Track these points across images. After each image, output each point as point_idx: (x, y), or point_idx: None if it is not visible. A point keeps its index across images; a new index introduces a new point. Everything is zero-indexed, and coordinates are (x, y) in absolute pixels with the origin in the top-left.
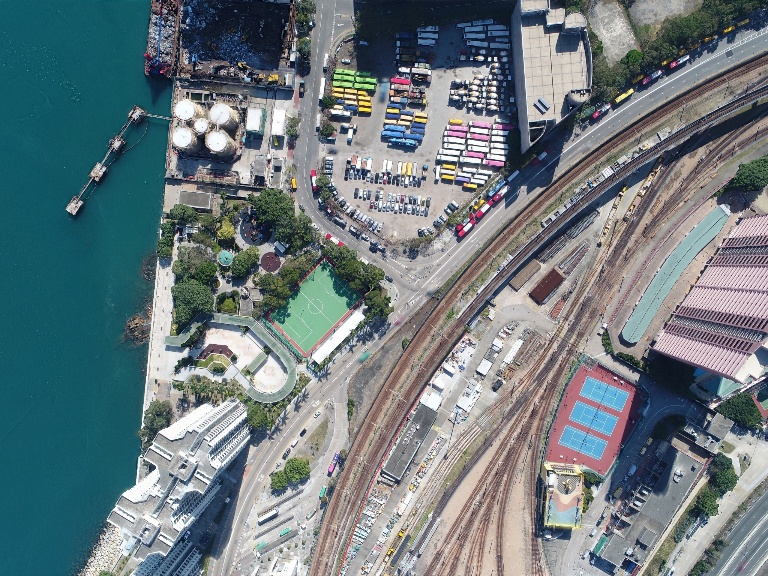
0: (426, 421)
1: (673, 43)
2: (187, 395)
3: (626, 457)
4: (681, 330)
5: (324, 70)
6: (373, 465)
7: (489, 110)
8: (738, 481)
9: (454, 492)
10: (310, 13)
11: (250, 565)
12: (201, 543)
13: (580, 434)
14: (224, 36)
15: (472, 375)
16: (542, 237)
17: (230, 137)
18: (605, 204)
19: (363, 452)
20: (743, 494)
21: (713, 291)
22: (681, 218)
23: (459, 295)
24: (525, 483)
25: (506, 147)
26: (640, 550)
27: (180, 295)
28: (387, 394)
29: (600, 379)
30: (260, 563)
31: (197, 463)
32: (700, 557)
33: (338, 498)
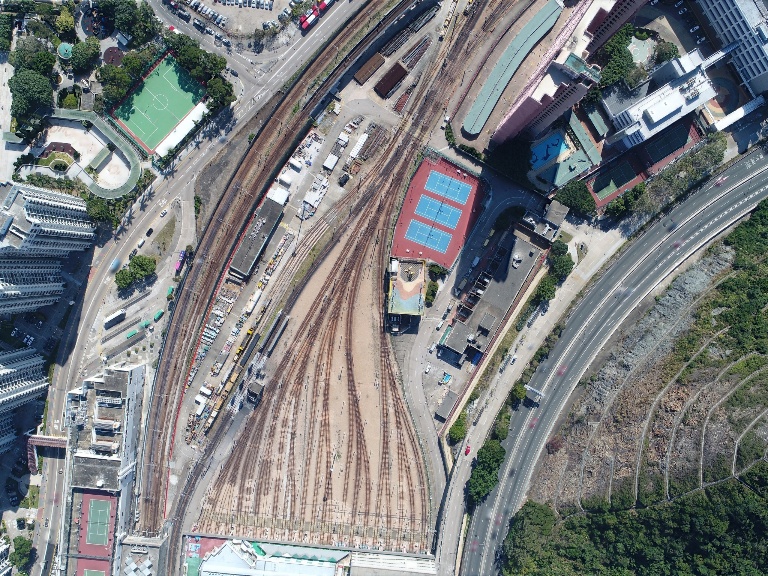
0: (272, 215)
1: None
2: None
3: (470, 250)
4: None
5: None
6: (220, 262)
7: None
8: (576, 270)
9: (303, 289)
10: None
11: (97, 371)
12: (45, 349)
13: (425, 228)
14: None
15: (319, 170)
16: (383, 26)
17: None
18: None
19: (211, 251)
20: (581, 283)
21: None
22: (519, 13)
23: (305, 89)
24: (373, 279)
25: None
26: (482, 337)
27: (16, 85)
28: (234, 191)
29: (444, 173)
30: None
31: (12, 217)
32: (541, 345)
33: (186, 298)
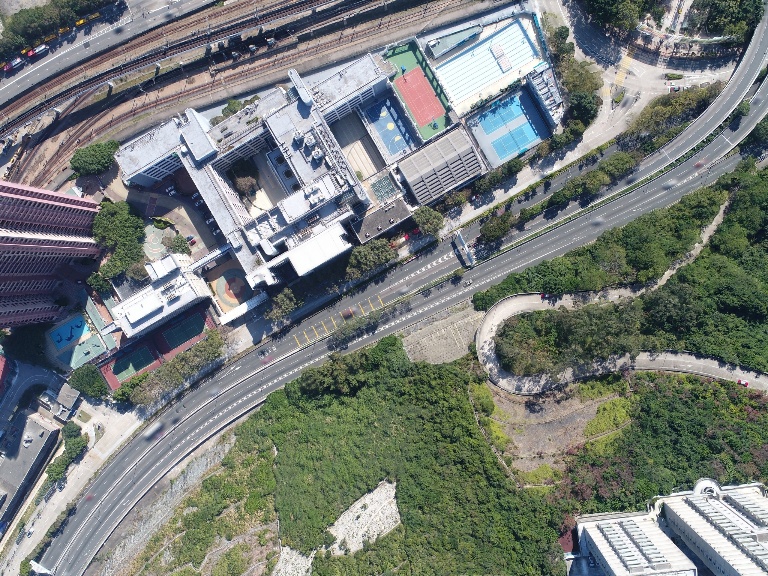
0: None
1: (17, 32)
2: None
3: None
4: None
5: None
6: None
7: None
8: (93, 449)
9: None
10: None
11: None
12: None
13: None
14: None
15: None
16: None
17: None
18: None
19: None
20: (98, 461)
21: None
22: None
23: None
24: None
25: None
26: None
27: None
28: None
29: None
30: None
31: None
32: None
33: None
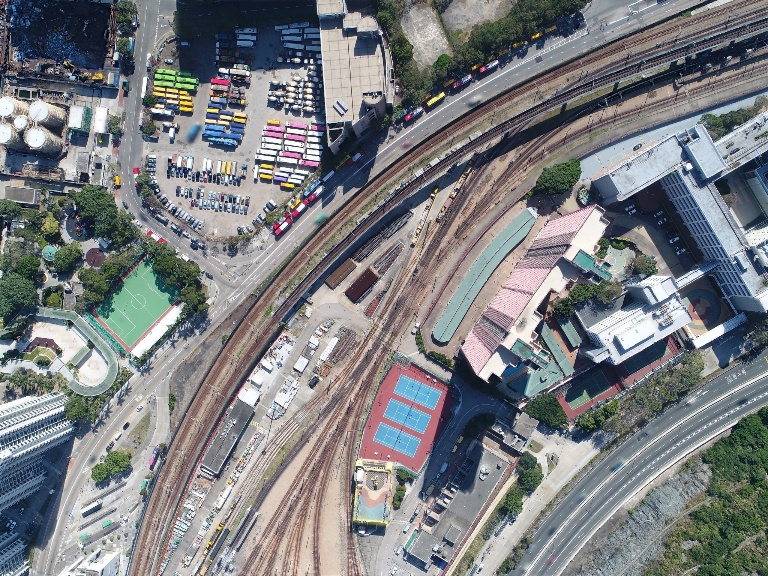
0: (243, 416)
1: (478, 48)
2: (14, 387)
3: (439, 455)
4: (478, 330)
5: (148, 70)
6: (192, 459)
7: (306, 111)
8: (546, 480)
9: (272, 487)
10: (131, 14)
11: (74, 556)
12: (26, 534)
13: (394, 431)
14: (50, 35)
15: (290, 372)
16: (353, 237)
17: (53, 134)
18: (418, 205)
19: (184, 446)
20: (551, 493)
21: (506, 292)
22: (492, 220)
23: (277, 293)
24: (341, 479)
25: (321, 148)
26: (447, 547)
27: (2, 288)
28: (207, 389)
29: (413, 377)
30: (84, 554)
31: None
32: (508, 554)
33: (160, 491)
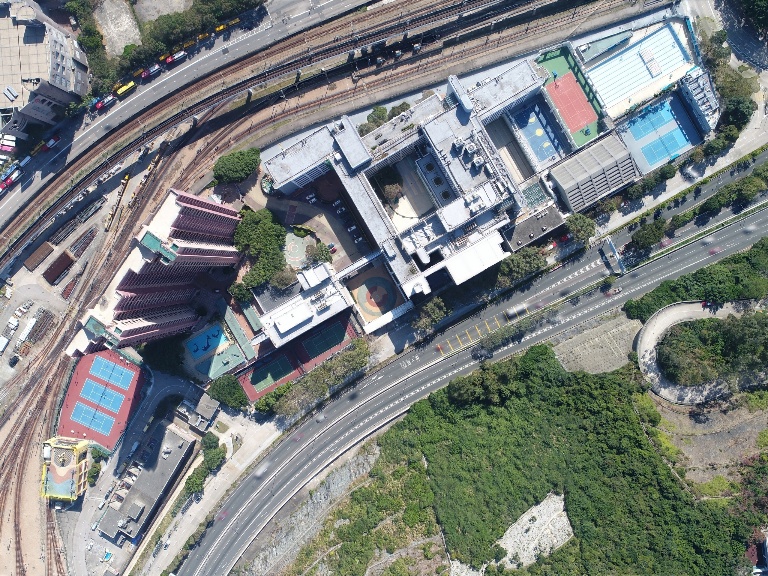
0: None
1: (159, 39)
2: None
3: (132, 434)
4: None
5: None
6: None
7: None
8: (231, 460)
9: None
10: None
11: None
12: None
13: (90, 410)
14: None
15: None
16: (44, 220)
17: None
18: (112, 191)
19: None
20: (236, 473)
21: None
22: None
23: None
24: None
25: None
26: (132, 523)
27: None
28: None
29: (108, 358)
30: None
31: None
32: None
33: None
